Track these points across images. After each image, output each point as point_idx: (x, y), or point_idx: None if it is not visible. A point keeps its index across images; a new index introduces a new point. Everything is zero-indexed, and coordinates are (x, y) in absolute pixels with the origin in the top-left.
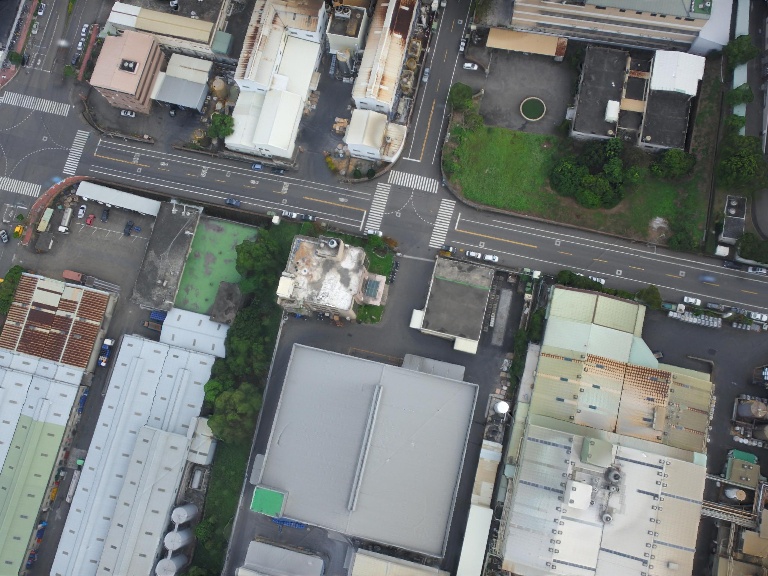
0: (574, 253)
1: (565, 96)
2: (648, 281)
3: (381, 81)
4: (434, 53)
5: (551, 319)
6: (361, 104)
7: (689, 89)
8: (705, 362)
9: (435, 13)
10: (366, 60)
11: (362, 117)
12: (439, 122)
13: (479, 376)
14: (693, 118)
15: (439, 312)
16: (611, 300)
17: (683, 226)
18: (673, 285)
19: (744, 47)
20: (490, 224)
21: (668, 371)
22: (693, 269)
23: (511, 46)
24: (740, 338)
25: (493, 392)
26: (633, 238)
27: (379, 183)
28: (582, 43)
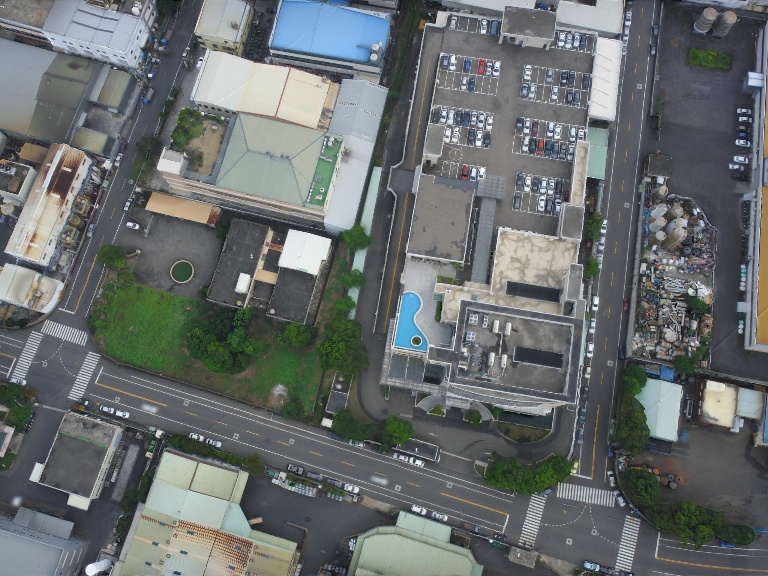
0: (199, 414)
1: (214, 261)
2: (261, 446)
3: (32, 239)
4: (102, 209)
5: (156, 482)
6: (17, 257)
7: (312, 269)
8: (301, 529)
9: (107, 172)
10: (23, 217)
11: (10, 272)
12: (98, 276)
13: (95, 530)
14: (323, 292)
15: (58, 467)
16: (211, 467)
17: (298, 396)
18: (282, 452)
19: (355, 237)
20: (128, 380)
21: (251, 541)
22: (302, 438)
23: (168, 211)
24: (334, 508)
25: (105, 547)
26: (253, 404)
27: (33, 332)
28: (236, 212)
